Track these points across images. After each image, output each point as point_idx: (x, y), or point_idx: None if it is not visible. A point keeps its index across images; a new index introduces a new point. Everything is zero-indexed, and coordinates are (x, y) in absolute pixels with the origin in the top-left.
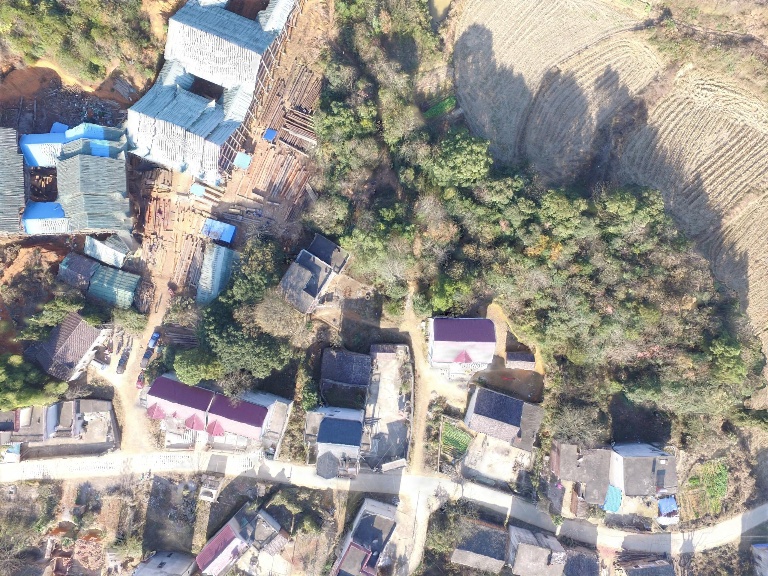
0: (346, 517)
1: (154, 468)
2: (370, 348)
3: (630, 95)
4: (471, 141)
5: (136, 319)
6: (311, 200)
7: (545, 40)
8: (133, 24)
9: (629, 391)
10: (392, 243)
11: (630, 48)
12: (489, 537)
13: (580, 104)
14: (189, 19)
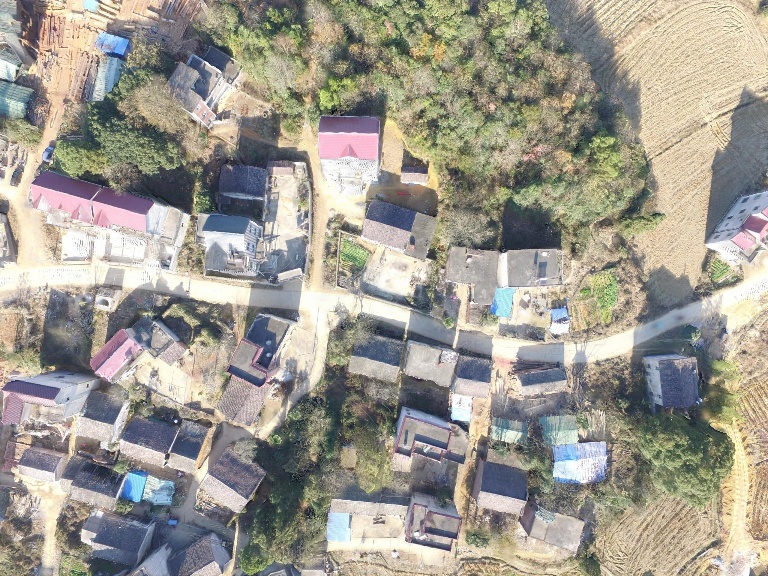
0: (245, 331)
1: (51, 282)
2: (267, 164)
3: None
4: None
5: (29, 131)
6: (206, 17)
7: None
8: None
9: (515, 193)
10: (279, 43)
11: None
12: (385, 346)
13: None
14: None
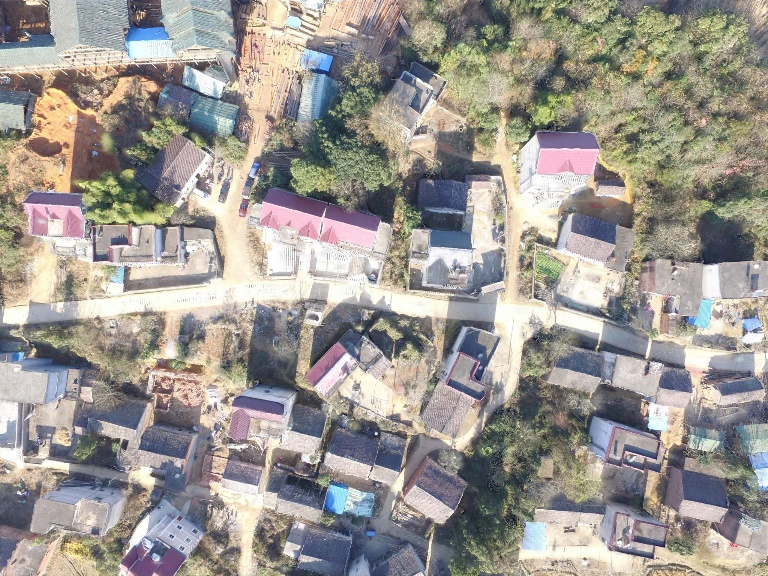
0: (445, 344)
1: (257, 297)
2: (465, 178)
3: None
4: None
5: (237, 148)
6: (405, 33)
7: None
8: None
9: (719, 206)
10: (494, 60)
11: None
12: (584, 357)
13: None
14: None
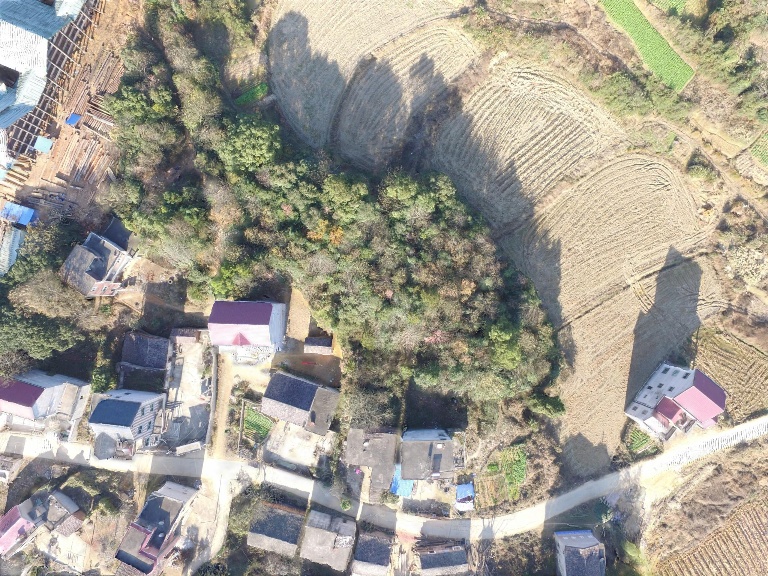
0: (146, 500)
1: None
2: (171, 332)
3: (445, 83)
4: (251, 125)
5: None
6: None
7: (360, 27)
8: None
9: (415, 376)
10: (174, 226)
11: (447, 36)
12: (285, 521)
13: (395, 91)
14: None
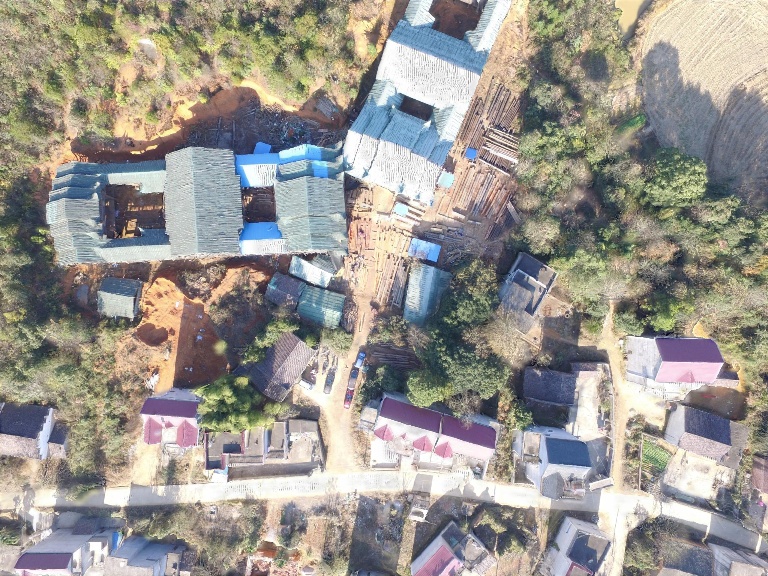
0: (548, 536)
1: (360, 488)
2: (571, 366)
3: None
4: (692, 161)
5: (344, 339)
6: (512, 219)
7: (731, 58)
8: (341, 44)
9: None
10: (612, 263)
11: None
12: (694, 555)
13: (766, 121)
14: (405, 40)
